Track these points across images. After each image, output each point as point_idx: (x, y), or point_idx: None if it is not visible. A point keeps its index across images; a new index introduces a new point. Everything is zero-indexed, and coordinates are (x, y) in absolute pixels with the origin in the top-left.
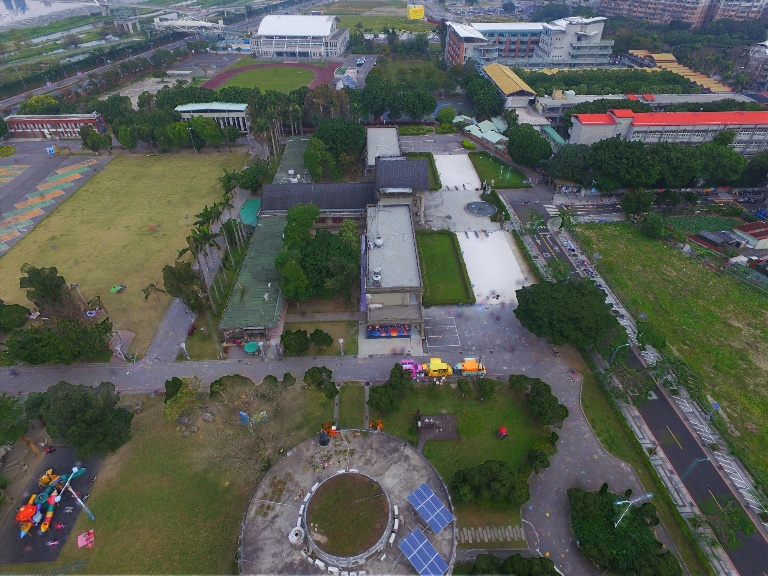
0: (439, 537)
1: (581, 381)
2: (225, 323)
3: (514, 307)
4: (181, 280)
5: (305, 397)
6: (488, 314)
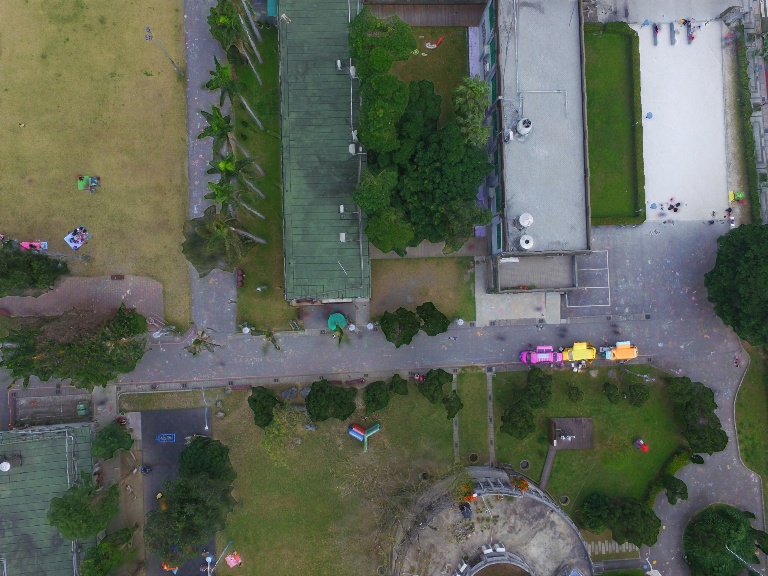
0: None
1: (746, 366)
2: (293, 291)
3: (696, 230)
4: (215, 255)
5: (417, 392)
6: (657, 245)
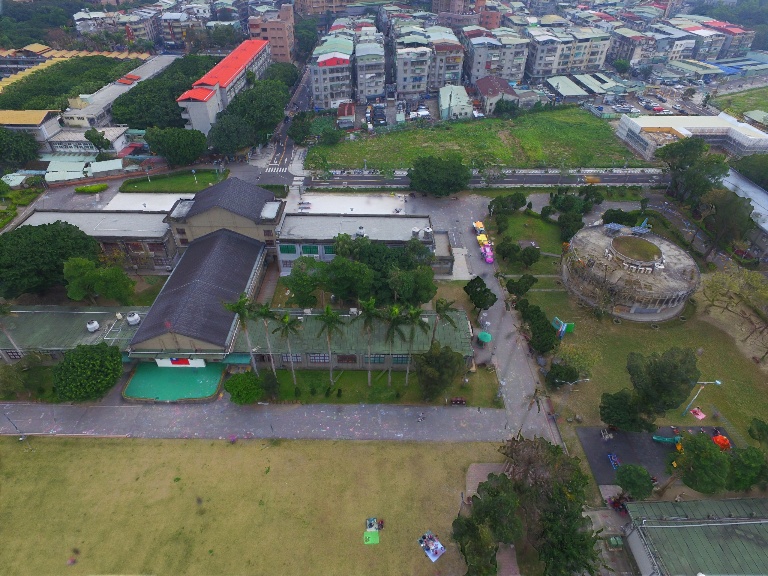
0: (623, 230)
1: (478, 195)
2: (467, 351)
3: (410, 206)
4: None
5: None
6: None
